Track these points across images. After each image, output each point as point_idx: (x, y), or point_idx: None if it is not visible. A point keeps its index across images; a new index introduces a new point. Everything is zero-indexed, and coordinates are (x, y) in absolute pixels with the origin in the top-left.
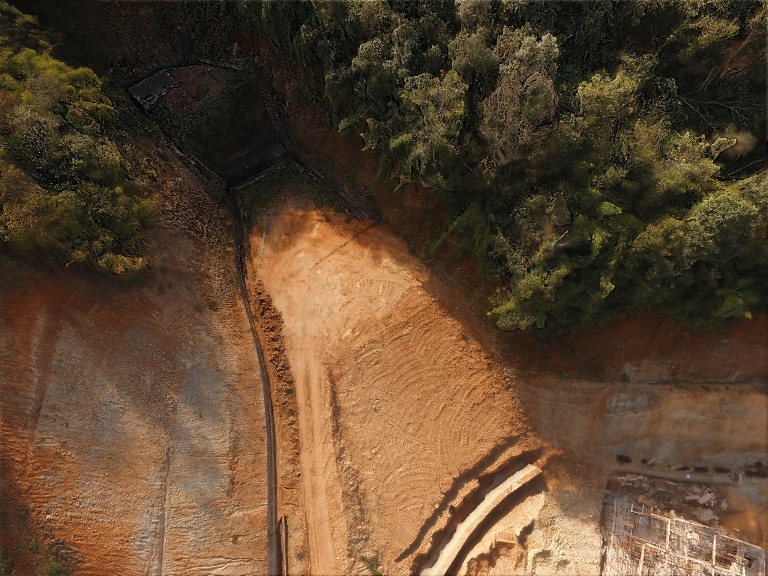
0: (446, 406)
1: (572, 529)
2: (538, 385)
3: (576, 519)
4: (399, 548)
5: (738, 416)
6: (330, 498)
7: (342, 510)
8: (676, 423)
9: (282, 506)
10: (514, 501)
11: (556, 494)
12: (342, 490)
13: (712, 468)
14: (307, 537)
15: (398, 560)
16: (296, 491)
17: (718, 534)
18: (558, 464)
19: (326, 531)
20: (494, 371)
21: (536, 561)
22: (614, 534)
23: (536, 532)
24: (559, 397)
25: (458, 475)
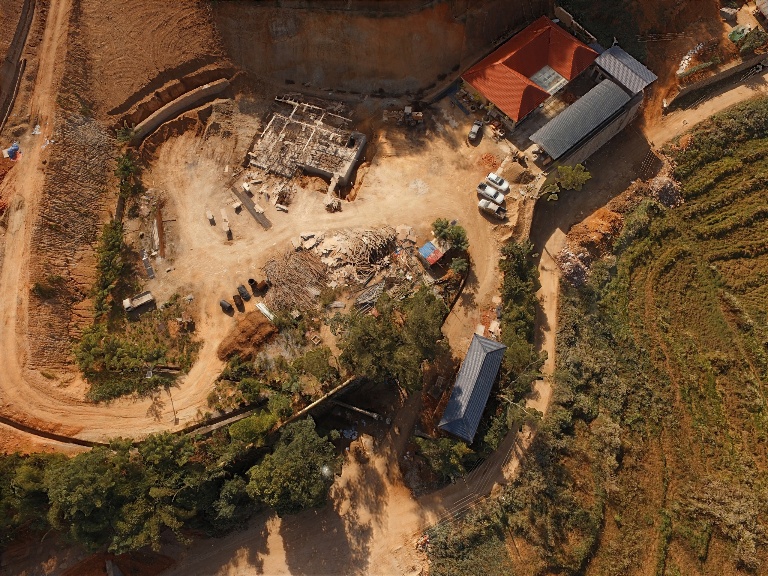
0: (161, 25)
1: (241, 118)
2: (226, 14)
3: (247, 114)
4: (111, 105)
5: (356, 40)
6: (58, 53)
7: (64, 60)
8: (318, 48)
9: (25, 54)
10: (207, 101)
11: (239, 101)
12: (67, 50)
13: (349, 91)
14: (37, 71)
15: (110, 114)
16: (37, 48)
17: (327, 112)
18: (244, 82)
19: (50, 69)
20: (201, 9)
21: (210, 132)
22: (272, 126)
23: (213, 113)
24: (240, 25)
25: (163, 70)
